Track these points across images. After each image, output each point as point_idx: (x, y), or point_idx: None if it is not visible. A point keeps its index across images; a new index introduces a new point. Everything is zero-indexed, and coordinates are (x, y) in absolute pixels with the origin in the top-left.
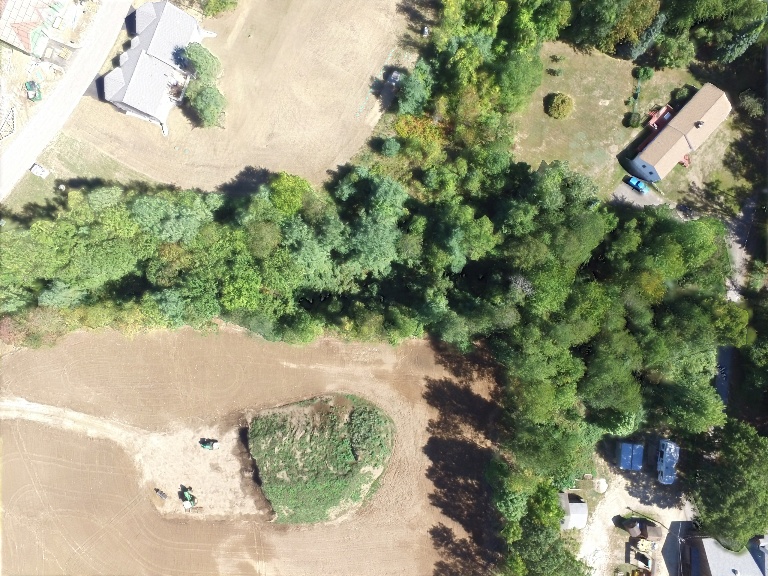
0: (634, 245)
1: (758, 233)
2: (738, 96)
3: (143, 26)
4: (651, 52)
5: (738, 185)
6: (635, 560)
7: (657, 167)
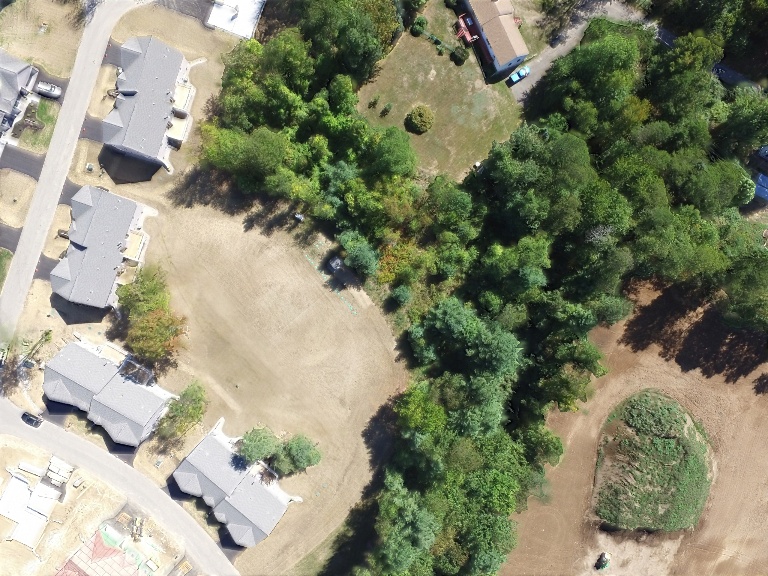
0: (595, 112)
1: None
2: None
3: (197, 489)
4: (401, 9)
5: None
6: None
7: (519, 54)
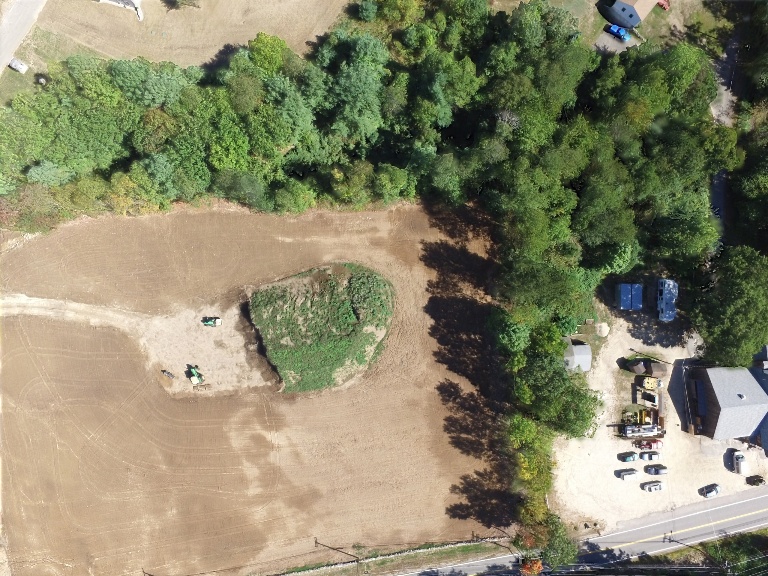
0: (618, 77)
1: (743, 73)
2: None
3: None
4: None
5: (720, 26)
6: (642, 400)
7: (636, 7)
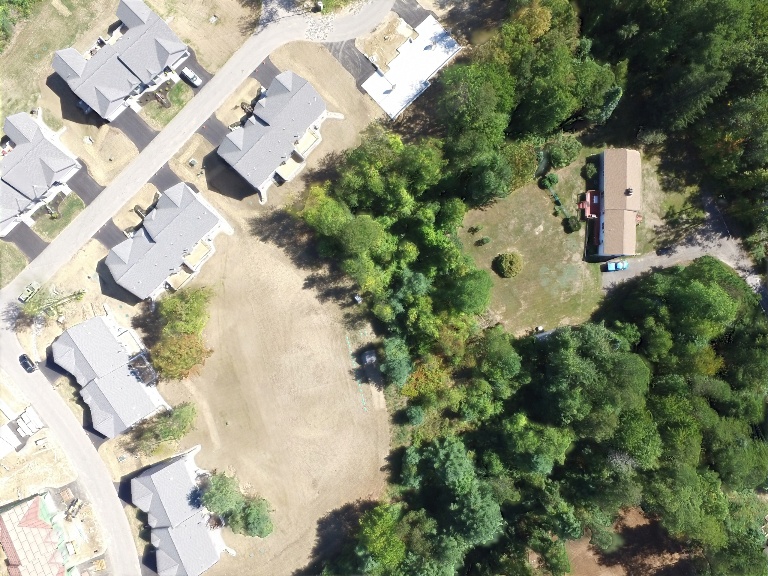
0: (670, 345)
1: (732, 218)
2: (632, 131)
3: (147, 505)
4: None
5: (688, 196)
6: None
7: (625, 252)
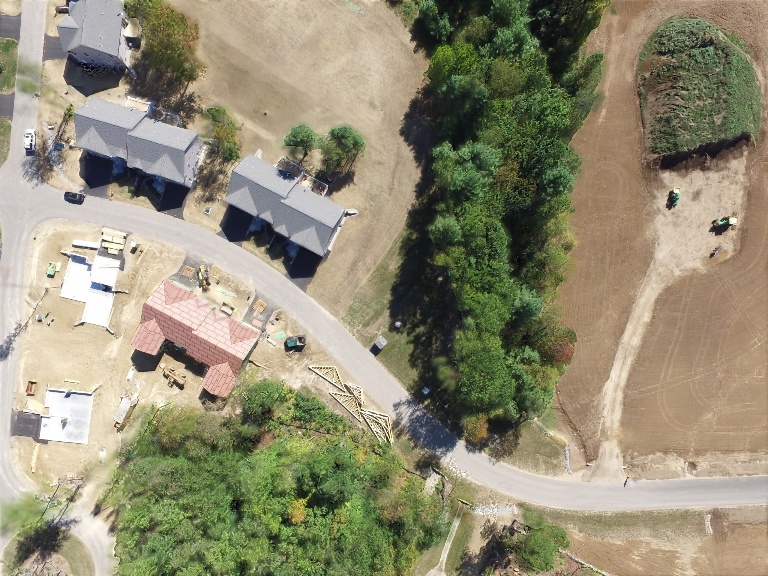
0: None
1: None
2: None
3: (252, 206)
4: None
5: None
6: None
7: None
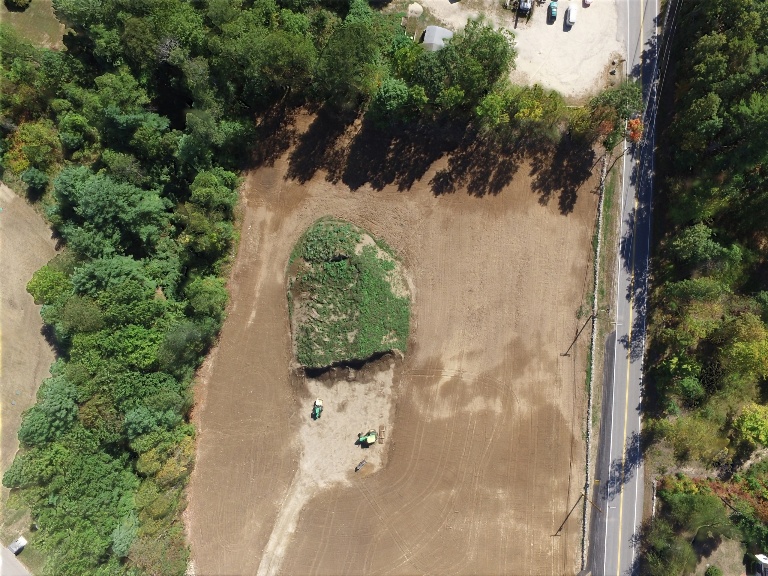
0: None
1: None
2: None
3: None
4: None
5: None
6: None
7: None
